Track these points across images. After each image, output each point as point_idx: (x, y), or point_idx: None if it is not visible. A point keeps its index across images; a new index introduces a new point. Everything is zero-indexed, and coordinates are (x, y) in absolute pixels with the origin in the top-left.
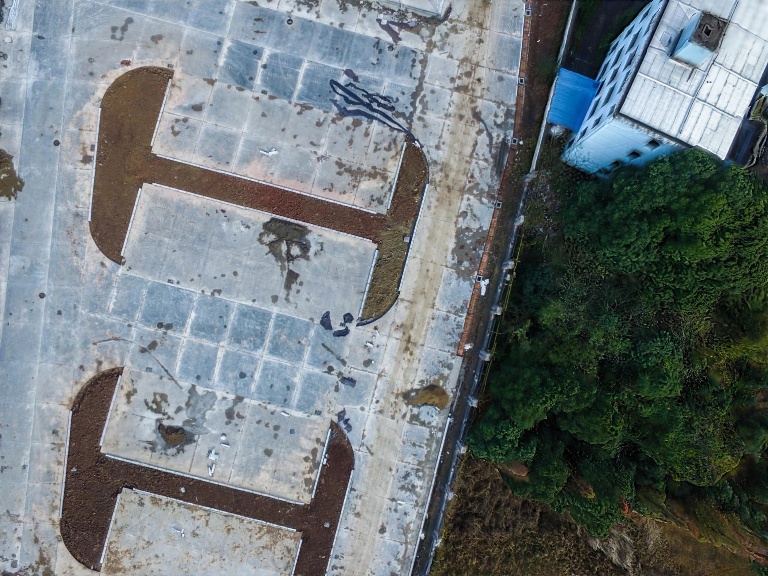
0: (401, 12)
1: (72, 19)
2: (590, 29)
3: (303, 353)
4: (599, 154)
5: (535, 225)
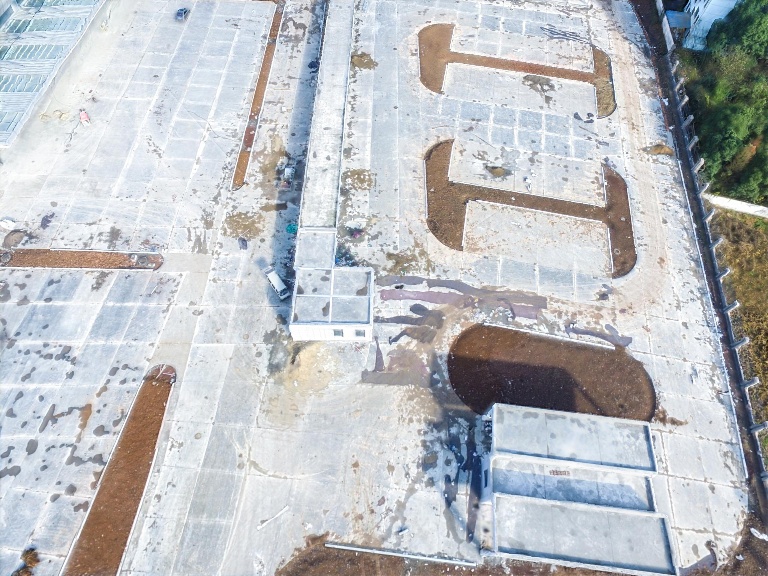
0: (567, 7)
1: (396, 9)
2: (669, 6)
3: (569, 131)
4: (710, 25)
5: None
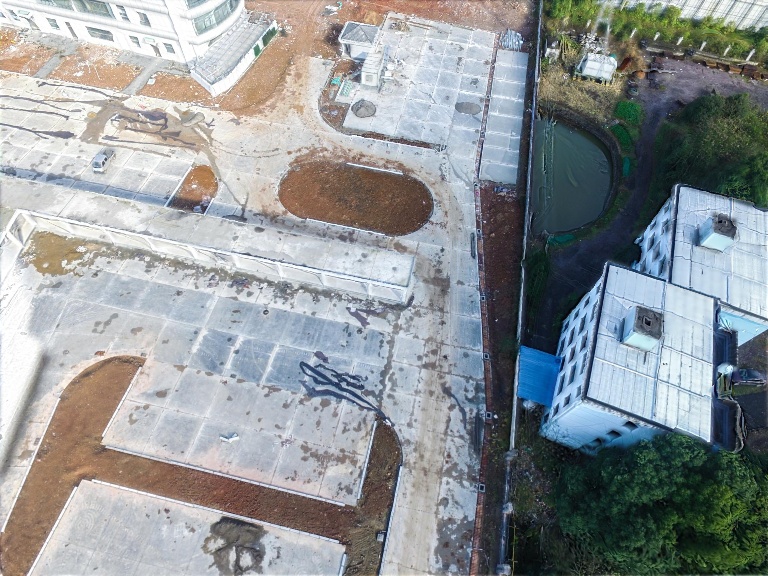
0: (369, 301)
1: (60, 316)
2: (541, 310)
3: None
4: (578, 431)
5: (527, 510)
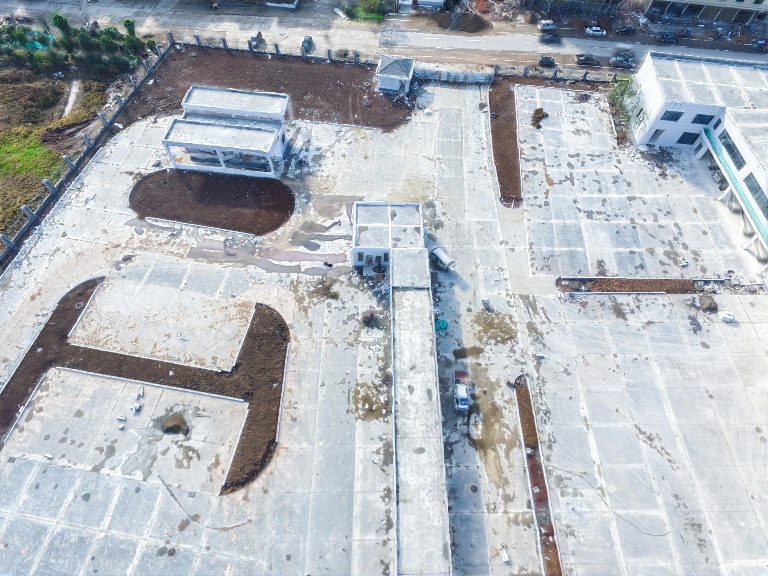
0: None
1: None
2: None
3: (6, 532)
4: None
5: None
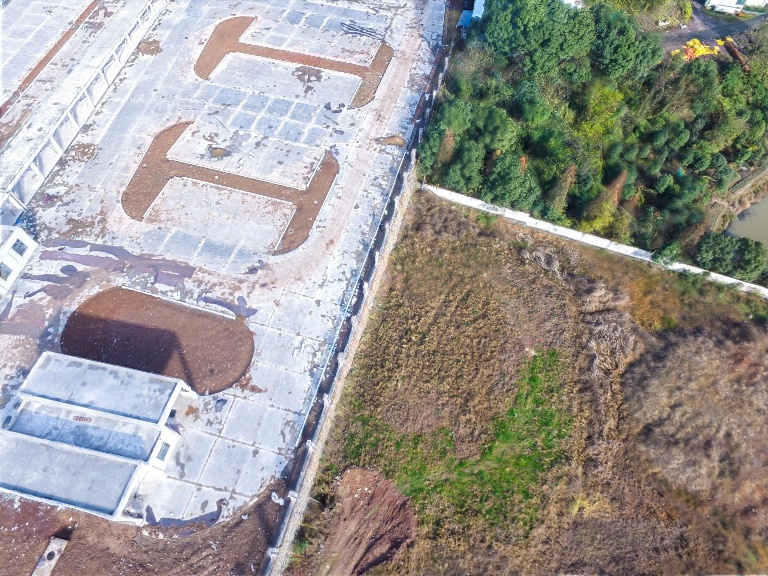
0: (381, 5)
1: (210, 2)
2: None
3: (311, 119)
4: None
5: None
